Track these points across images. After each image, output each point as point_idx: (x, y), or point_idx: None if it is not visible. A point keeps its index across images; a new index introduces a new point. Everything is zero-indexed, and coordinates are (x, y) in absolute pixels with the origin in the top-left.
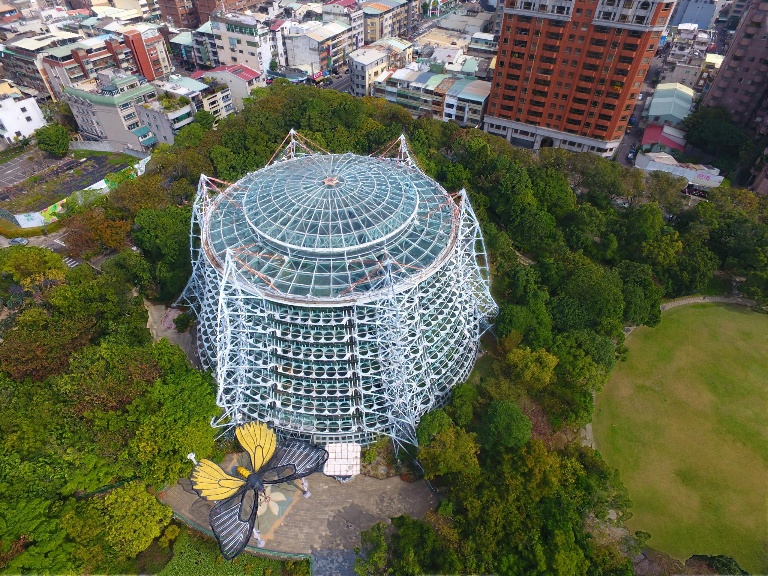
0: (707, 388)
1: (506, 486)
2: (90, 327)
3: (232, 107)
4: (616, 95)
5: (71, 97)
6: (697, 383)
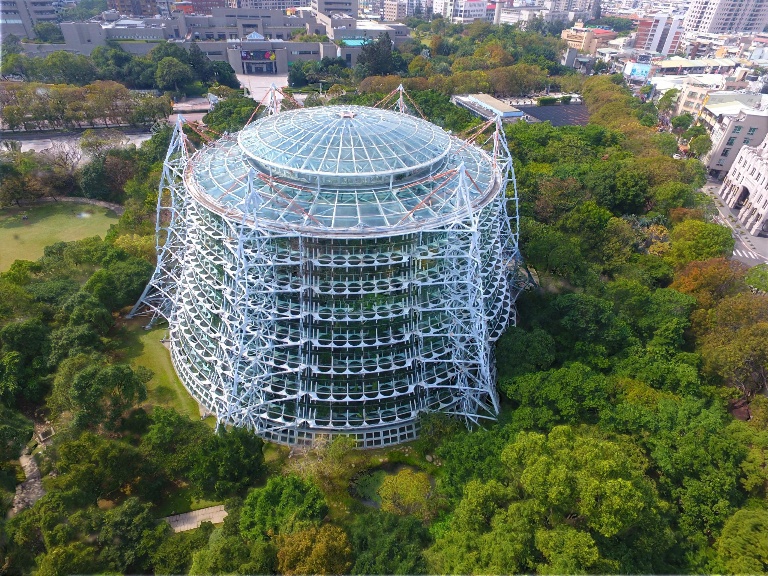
0: None
1: None
2: None
3: None
4: None
5: None
6: None
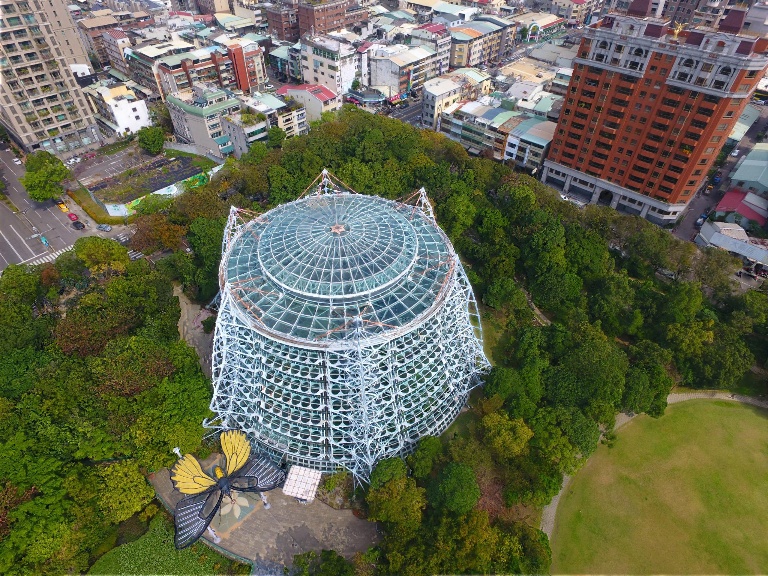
0: (699, 496)
1: (436, 548)
2: (130, 318)
3: (305, 124)
4: (685, 158)
5: (171, 104)
6: (689, 488)
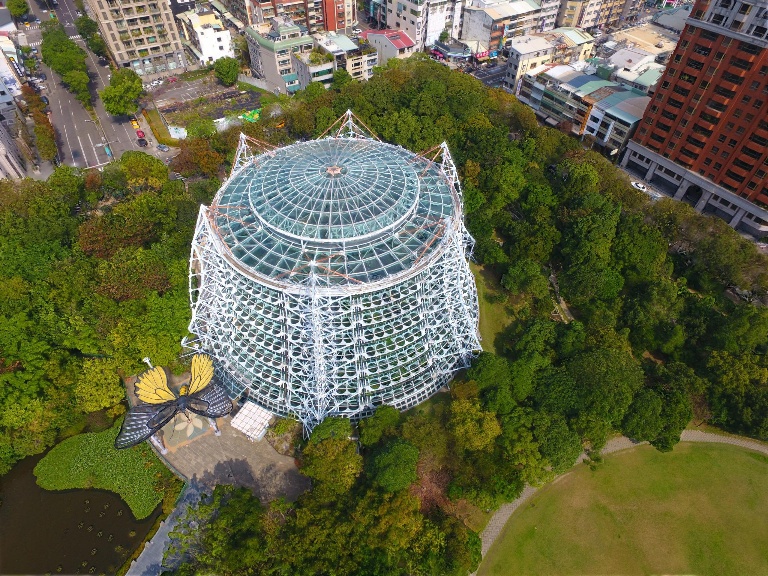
0: (686, 552)
1: (351, 518)
2: (148, 232)
3: None
4: None
5: (248, 36)
6: (677, 540)
